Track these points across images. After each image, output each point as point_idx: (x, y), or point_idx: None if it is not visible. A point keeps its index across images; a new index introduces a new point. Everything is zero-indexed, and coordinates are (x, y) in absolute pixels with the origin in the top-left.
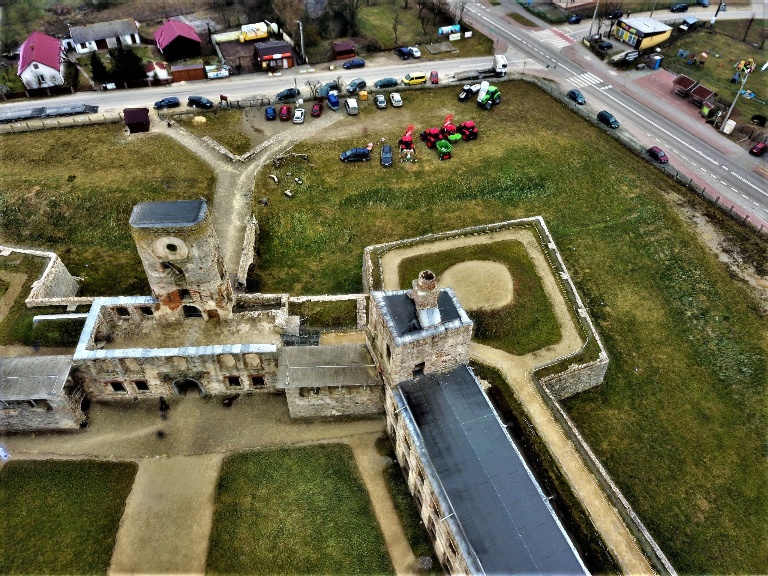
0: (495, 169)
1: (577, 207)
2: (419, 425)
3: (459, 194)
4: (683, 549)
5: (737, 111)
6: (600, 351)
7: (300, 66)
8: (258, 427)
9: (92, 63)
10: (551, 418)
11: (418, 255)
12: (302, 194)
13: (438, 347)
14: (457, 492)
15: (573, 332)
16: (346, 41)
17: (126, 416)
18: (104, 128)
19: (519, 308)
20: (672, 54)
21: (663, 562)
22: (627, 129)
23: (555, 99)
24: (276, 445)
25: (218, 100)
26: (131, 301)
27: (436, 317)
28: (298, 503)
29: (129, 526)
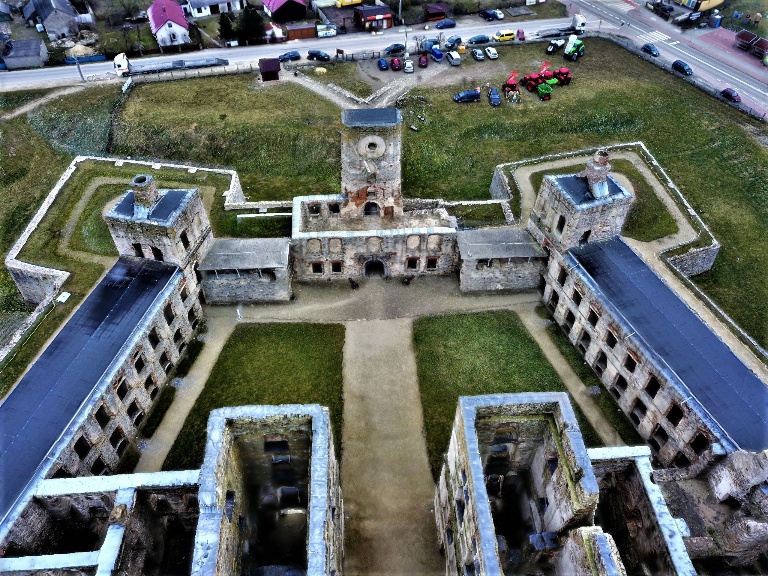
0: (590, 108)
1: (665, 138)
2: (593, 276)
3: (561, 128)
4: None
5: None
6: (712, 239)
7: (397, 27)
8: (436, 299)
9: (221, 22)
10: (682, 285)
11: (544, 170)
12: (426, 129)
13: (604, 216)
14: (635, 318)
15: (687, 225)
16: (433, 6)
17: (324, 292)
18: (238, 77)
19: (642, 206)
20: (728, 16)
21: None
22: (700, 76)
23: (631, 52)
24: (454, 311)
25: (333, 54)
26: (325, 198)
27: (605, 190)
28: (482, 351)
29: (350, 367)
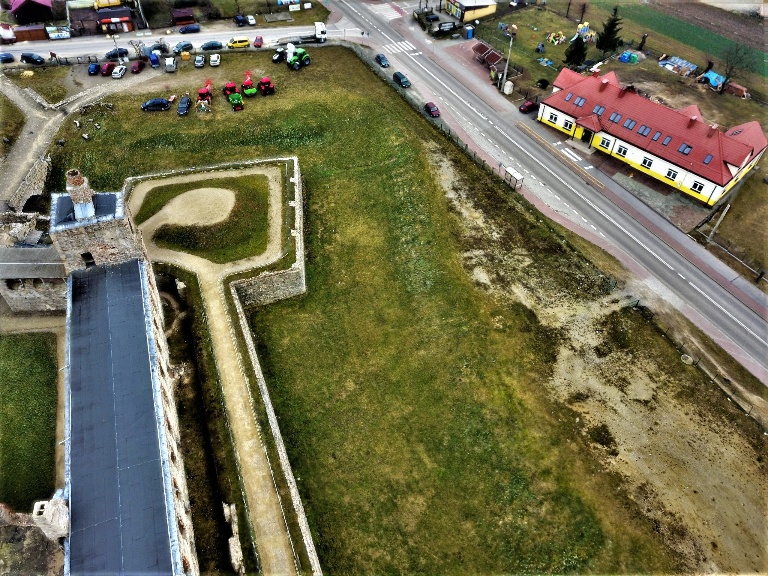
0: (280, 119)
1: (346, 153)
2: (73, 302)
3: (243, 140)
4: (316, 418)
5: (528, 76)
6: (294, 262)
7: (141, 30)
8: None
9: None
10: (225, 311)
11: (169, 185)
12: (98, 137)
13: (96, 238)
14: (79, 349)
15: (277, 247)
16: (193, 10)
17: None
18: None
19: (231, 226)
20: (493, 27)
21: (268, 417)
22: (417, 89)
23: (363, 62)
24: None
25: None
26: None
27: (89, 211)
28: None
29: None
